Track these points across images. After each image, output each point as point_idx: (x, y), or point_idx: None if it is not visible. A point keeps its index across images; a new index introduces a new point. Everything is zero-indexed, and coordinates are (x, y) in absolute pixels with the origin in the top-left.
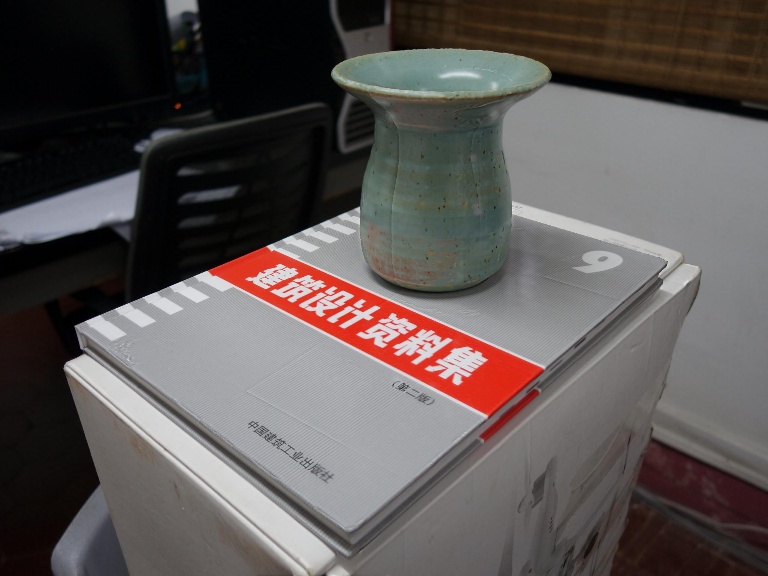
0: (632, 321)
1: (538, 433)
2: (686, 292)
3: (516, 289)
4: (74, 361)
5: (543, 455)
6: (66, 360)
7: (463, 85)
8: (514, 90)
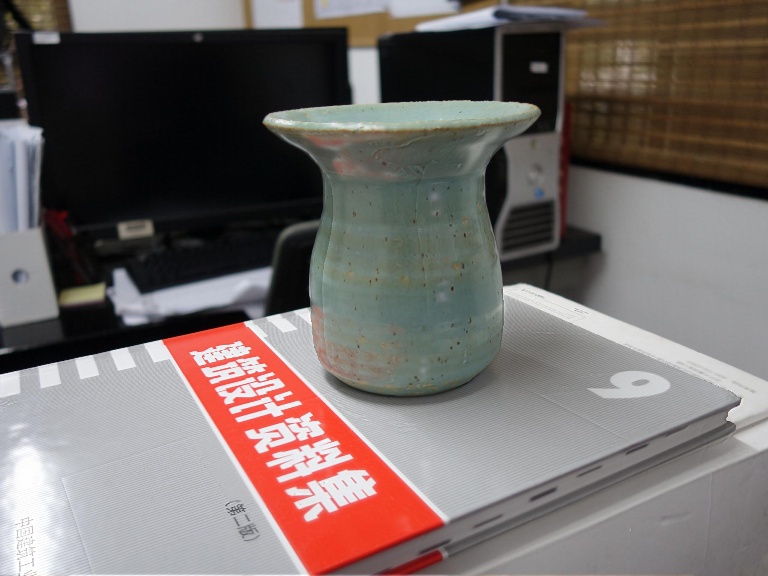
0: (668, 479)
1: None
2: None
3: (489, 405)
4: None
5: None
6: None
7: None
8: (446, 124)
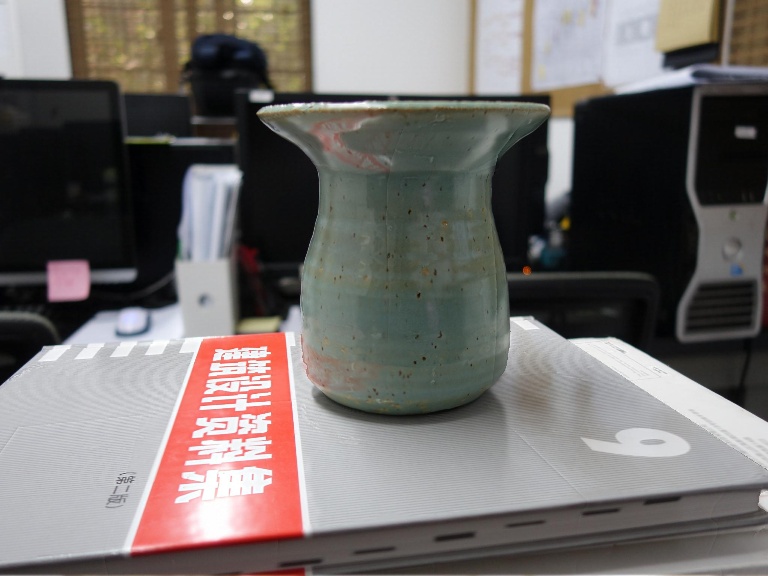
0: (655, 564)
1: None
2: None
3: (453, 435)
4: None
5: None
6: None
7: None
8: (394, 105)
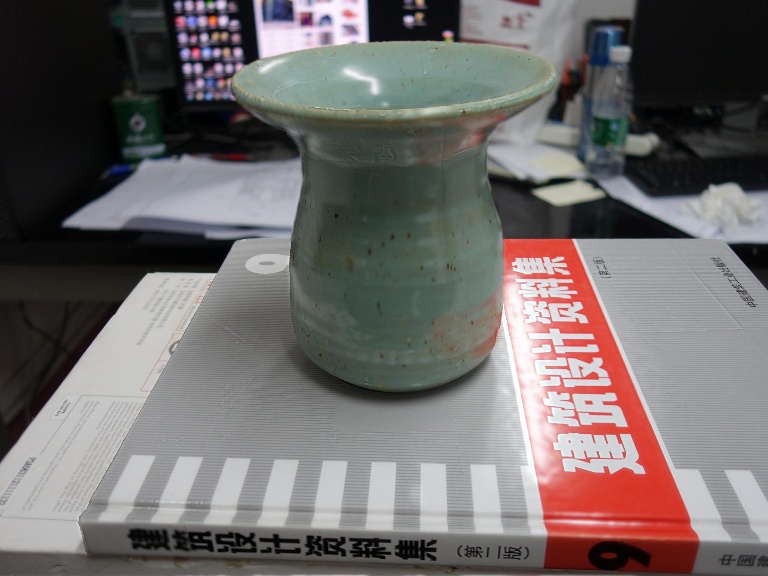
0: None
1: None
2: None
3: None
4: None
5: None
6: None
7: None
8: None
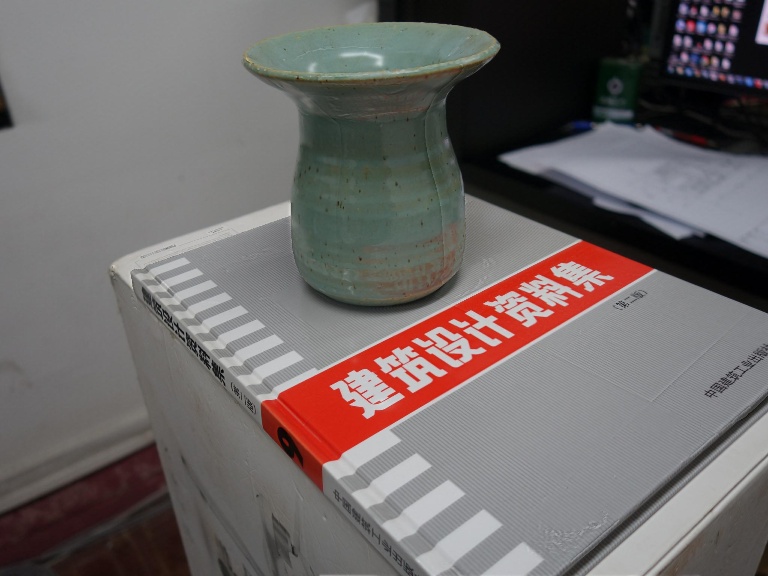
0: None
1: None
2: None
3: None
4: None
5: None
6: None
7: None
8: None
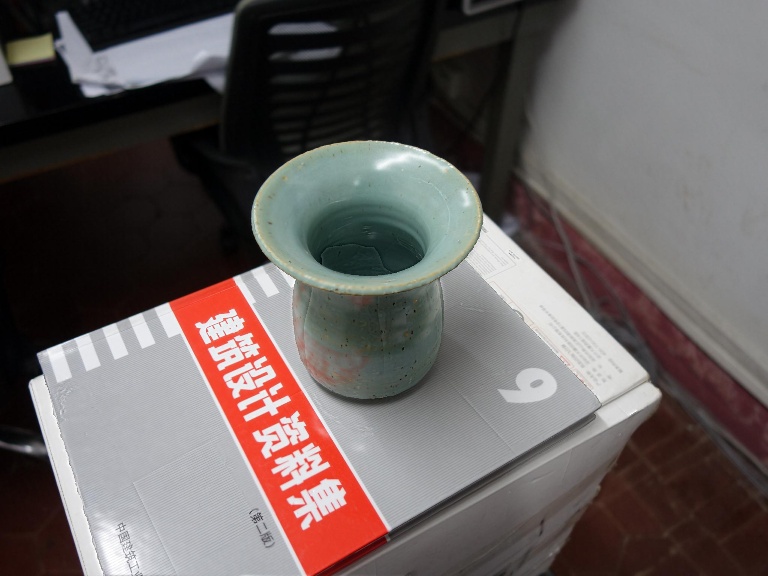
0: (542, 456)
1: (387, 564)
2: (632, 419)
3: (426, 408)
4: (36, 382)
5: (396, 574)
6: (31, 378)
7: (414, 198)
8: (402, 288)
